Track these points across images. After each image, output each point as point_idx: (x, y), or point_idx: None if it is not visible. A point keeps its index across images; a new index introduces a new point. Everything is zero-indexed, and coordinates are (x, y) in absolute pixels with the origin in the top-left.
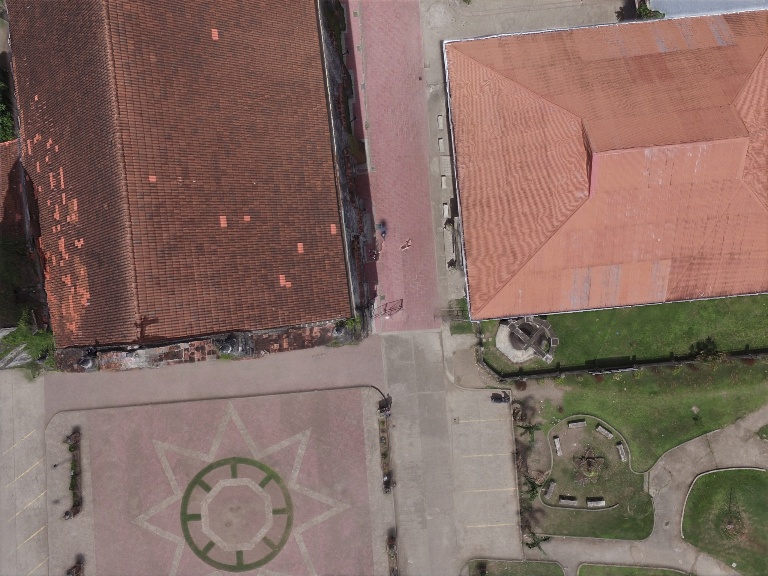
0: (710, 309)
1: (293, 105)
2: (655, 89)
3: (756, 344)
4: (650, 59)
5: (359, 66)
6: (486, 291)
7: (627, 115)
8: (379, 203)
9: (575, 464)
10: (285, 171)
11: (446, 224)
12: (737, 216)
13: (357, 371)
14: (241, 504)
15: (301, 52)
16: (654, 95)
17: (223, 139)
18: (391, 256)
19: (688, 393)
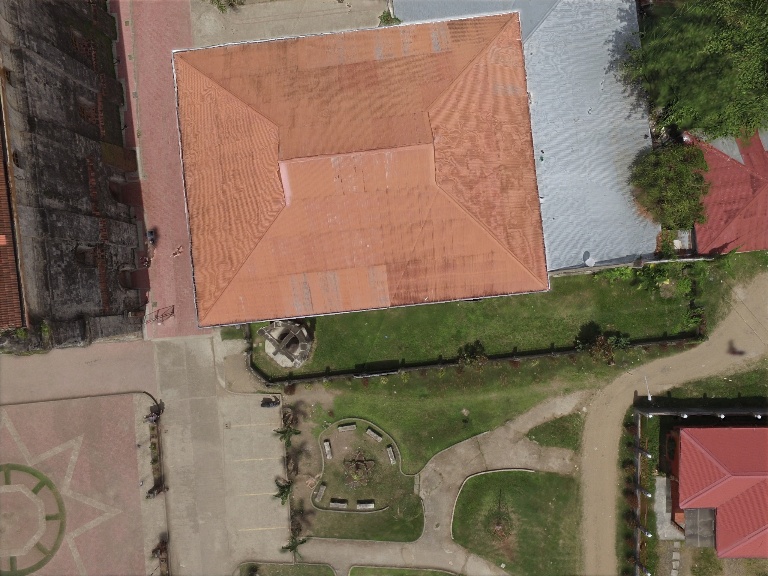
0: (478, 312)
1: None
2: (358, 97)
3: (524, 346)
4: (363, 67)
5: (131, 75)
6: (210, 298)
7: (323, 123)
8: (151, 210)
9: (345, 467)
10: None
11: None
12: (441, 221)
13: (130, 377)
14: (15, 510)
15: None
16: (355, 103)
17: None
18: (163, 263)
19: (458, 396)
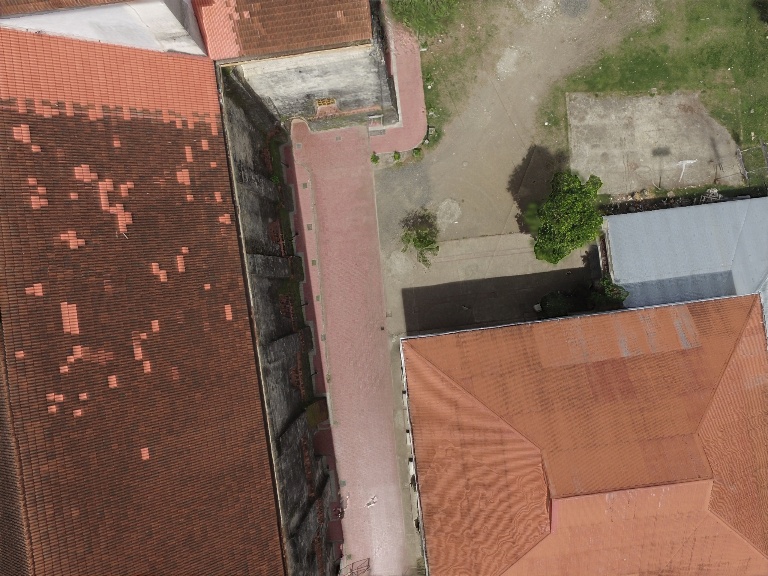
0: None
1: (234, 493)
2: (617, 409)
3: None
4: (612, 366)
5: (319, 317)
6: None
7: (588, 445)
8: (343, 458)
9: None
10: (226, 571)
11: (412, 482)
12: (704, 538)
13: None
14: None
15: (242, 429)
16: (616, 417)
17: (156, 567)
18: (356, 513)
19: None
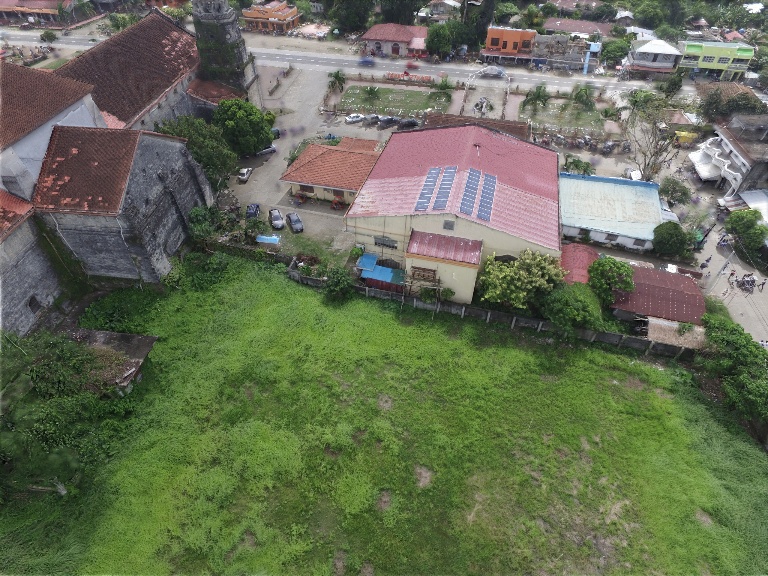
0: None
1: None
2: None
3: None
4: None
5: None
6: None
7: None
8: None
9: None
10: None
11: None
12: None
13: None
14: None
15: None
16: None
17: None
18: None
19: None
